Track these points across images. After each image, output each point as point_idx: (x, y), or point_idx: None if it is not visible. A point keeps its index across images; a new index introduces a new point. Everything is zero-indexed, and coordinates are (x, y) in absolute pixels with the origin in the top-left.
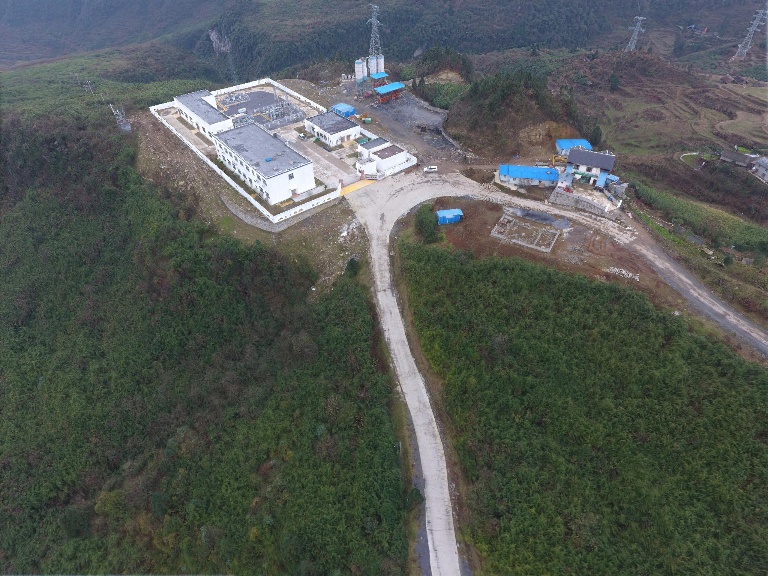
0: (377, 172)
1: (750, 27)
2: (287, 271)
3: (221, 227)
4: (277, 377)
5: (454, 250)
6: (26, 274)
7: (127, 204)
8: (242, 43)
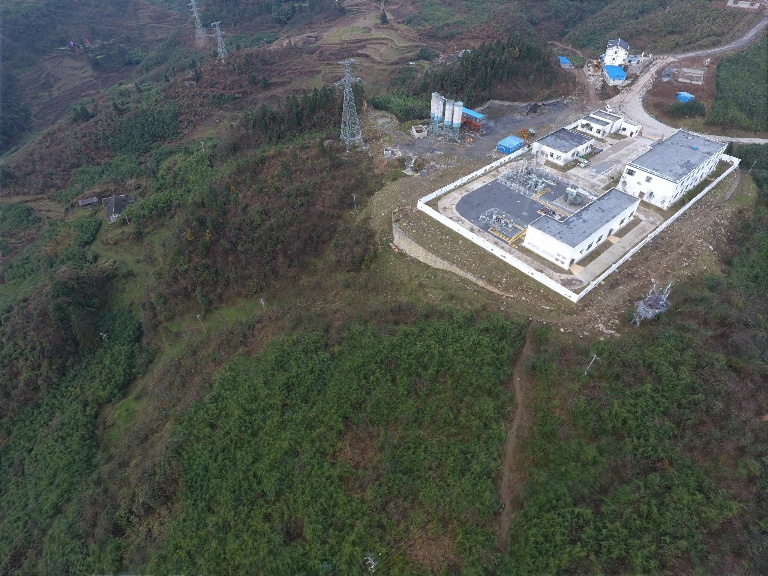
0: None
1: (193, 14)
2: None
3: None
4: None
5: (712, 101)
6: None
7: None
8: None
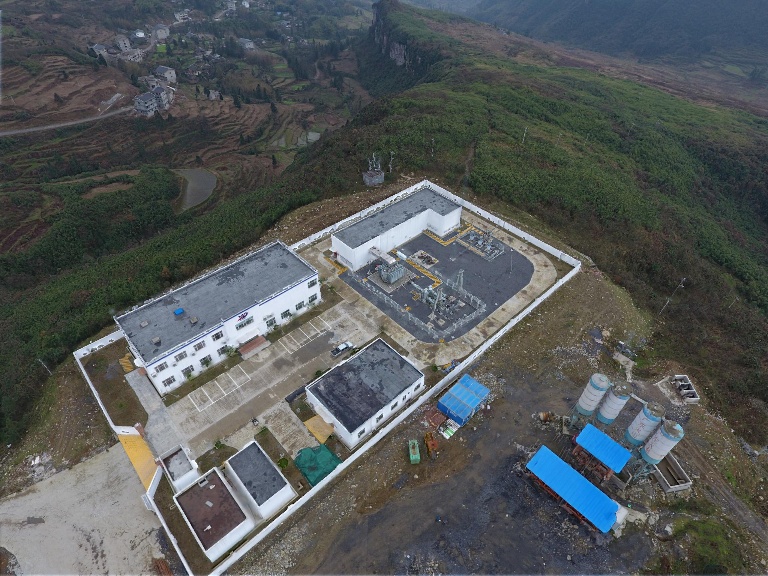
0: None
1: None
2: None
3: None
4: None
5: None
6: None
7: None
8: None
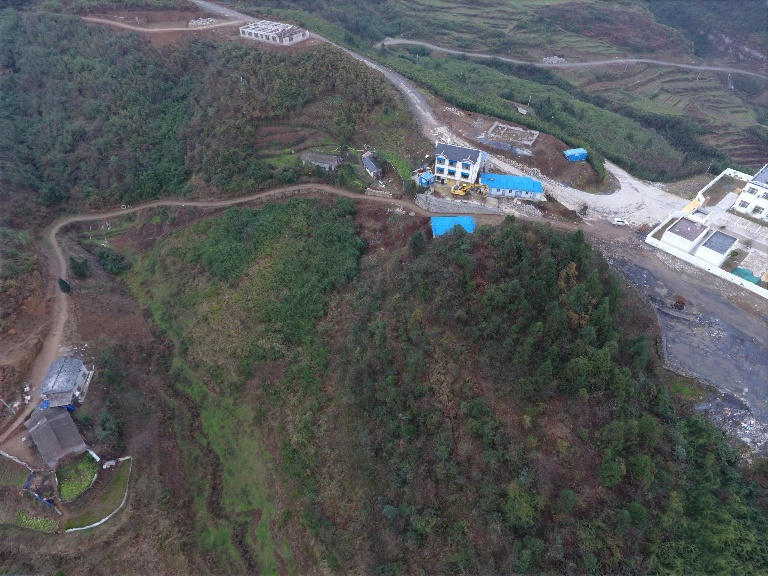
0: None
1: None
2: None
3: None
4: None
5: None
6: None
7: None
8: None
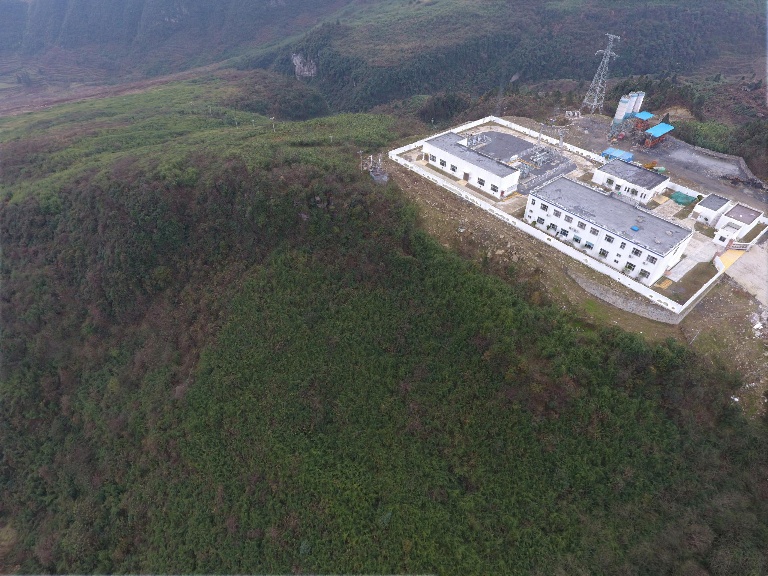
0: (735, 239)
1: None
2: (722, 380)
3: (590, 314)
4: (765, 535)
5: None
6: (305, 362)
7: (435, 278)
8: (333, 68)
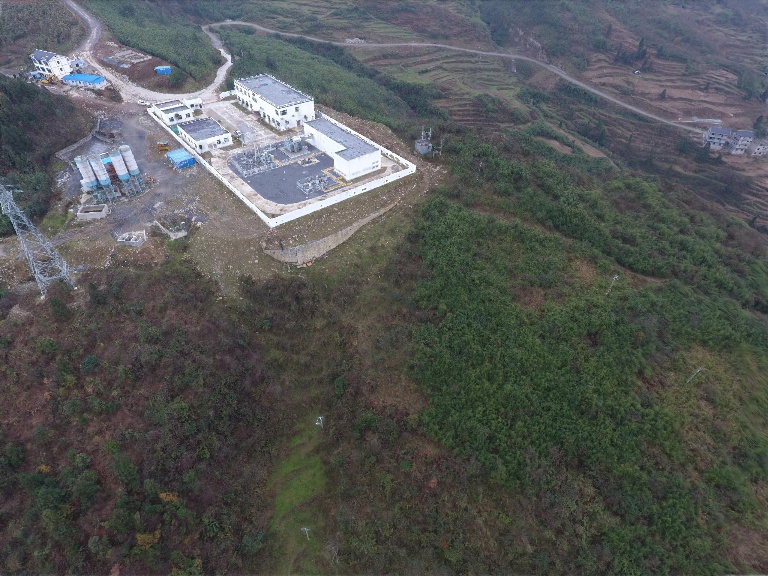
0: None
1: None
2: None
3: None
4: None
5: None
6: None
7: None
8: None
